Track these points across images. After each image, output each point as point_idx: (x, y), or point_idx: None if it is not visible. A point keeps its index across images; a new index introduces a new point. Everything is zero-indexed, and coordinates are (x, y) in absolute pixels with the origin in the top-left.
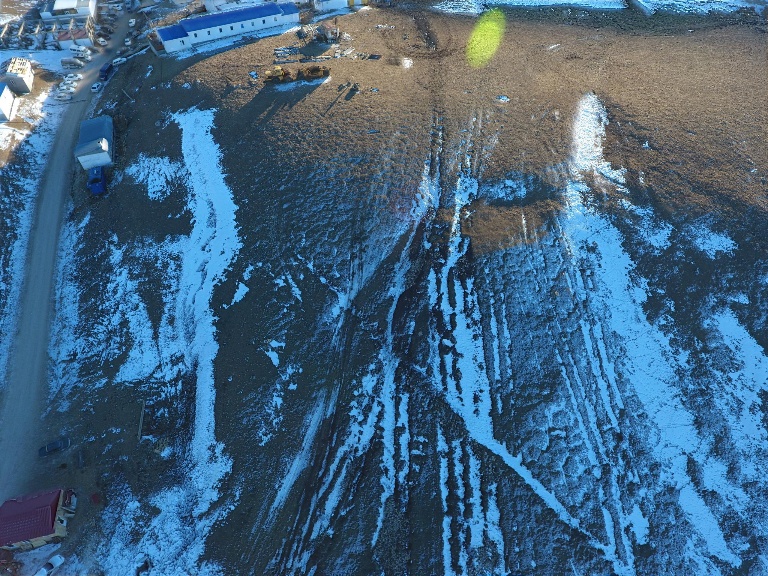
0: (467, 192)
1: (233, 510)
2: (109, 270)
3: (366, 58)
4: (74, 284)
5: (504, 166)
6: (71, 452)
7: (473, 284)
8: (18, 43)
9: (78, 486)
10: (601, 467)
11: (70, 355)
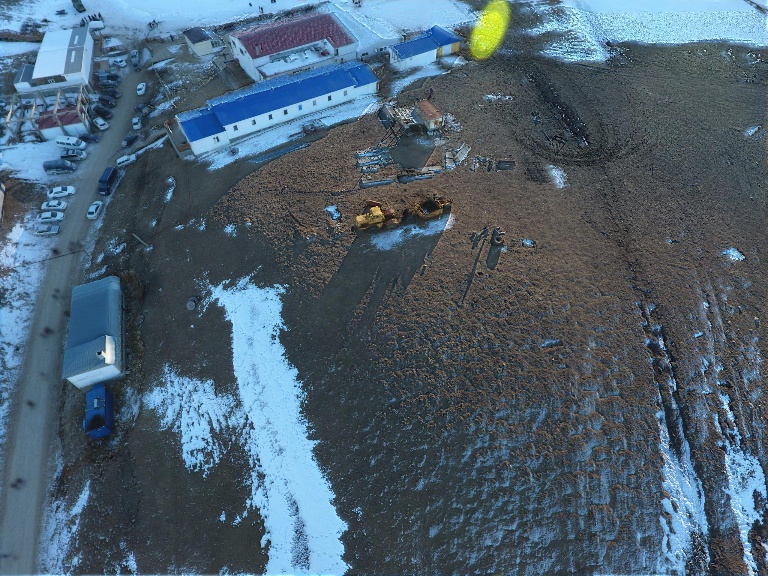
0: (748, 490)
1: None
2: None
3: (493, 168)
4: None
5: None
6: None
7: None
8: None
9: None
10: None
11: None
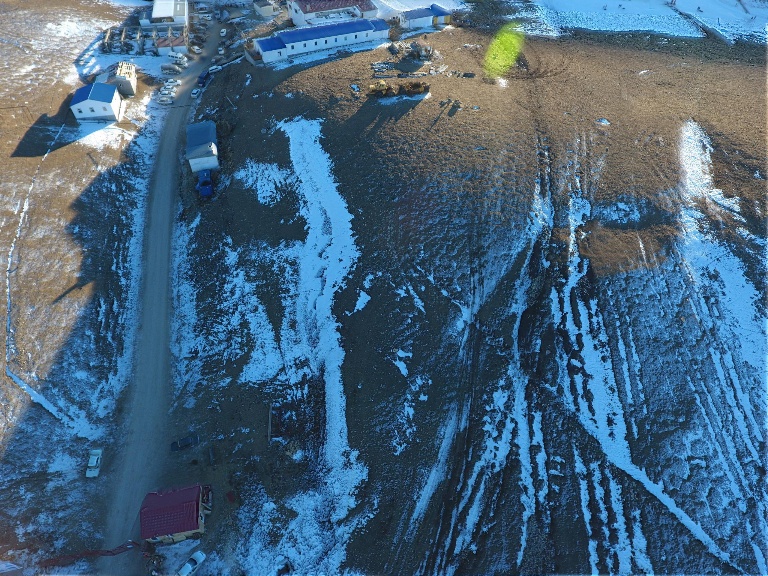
0: (580, 213)
1: (372, 518)
2: (225, 271)
3: (461, 76)
4: (190, 283)
5: (615, 189)
6: (201, 449)
7: (597, 305)
8: (120, 48)
9: (211, 483)
10: (746, 501)
11: (192, 352)
